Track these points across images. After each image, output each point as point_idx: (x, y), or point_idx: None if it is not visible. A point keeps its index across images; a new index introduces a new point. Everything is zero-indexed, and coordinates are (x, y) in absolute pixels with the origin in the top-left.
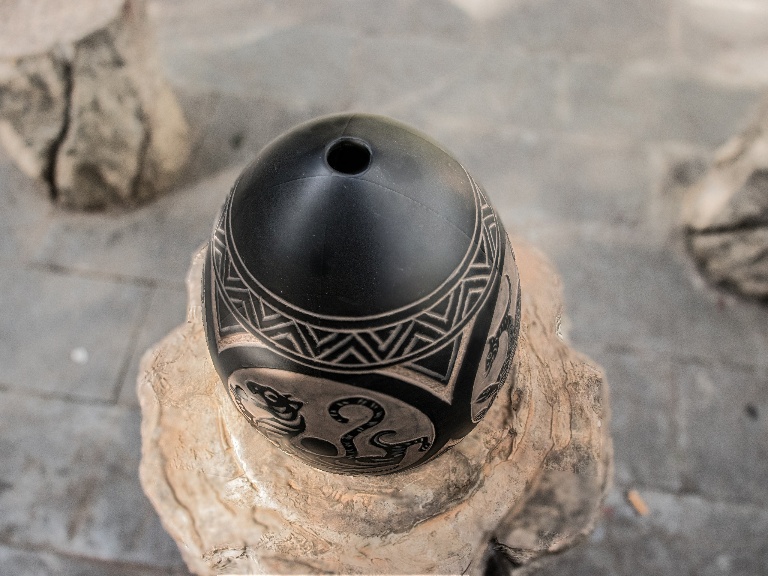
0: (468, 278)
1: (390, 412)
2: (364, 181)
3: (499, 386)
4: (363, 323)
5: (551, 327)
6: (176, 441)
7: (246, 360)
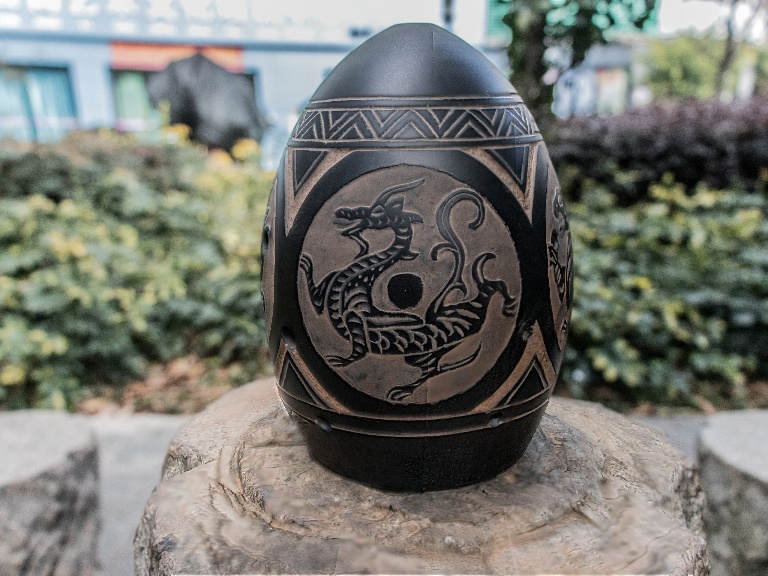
0: None
1: None
2: None
3: None
4: None
5: None
6: (566, 570)
7: (544, 178)
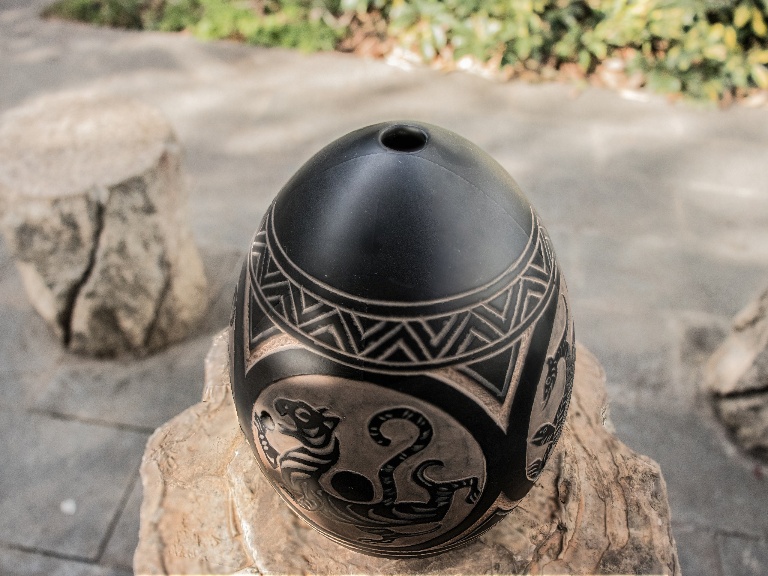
0: (527, 277)
1: (438, 432)
2: (420, 158)
3: (555, 435)
4: (415, 310)
5: (596, 418)
6: (179, 525)
7: (278, 370)
